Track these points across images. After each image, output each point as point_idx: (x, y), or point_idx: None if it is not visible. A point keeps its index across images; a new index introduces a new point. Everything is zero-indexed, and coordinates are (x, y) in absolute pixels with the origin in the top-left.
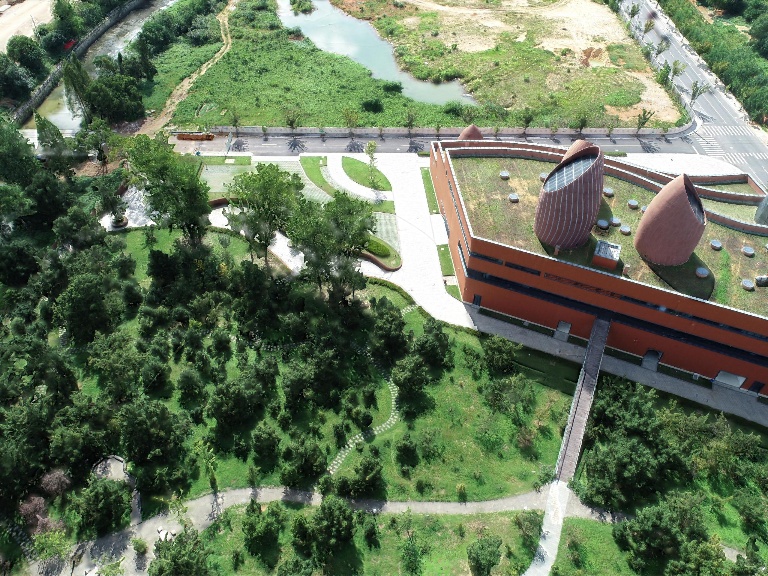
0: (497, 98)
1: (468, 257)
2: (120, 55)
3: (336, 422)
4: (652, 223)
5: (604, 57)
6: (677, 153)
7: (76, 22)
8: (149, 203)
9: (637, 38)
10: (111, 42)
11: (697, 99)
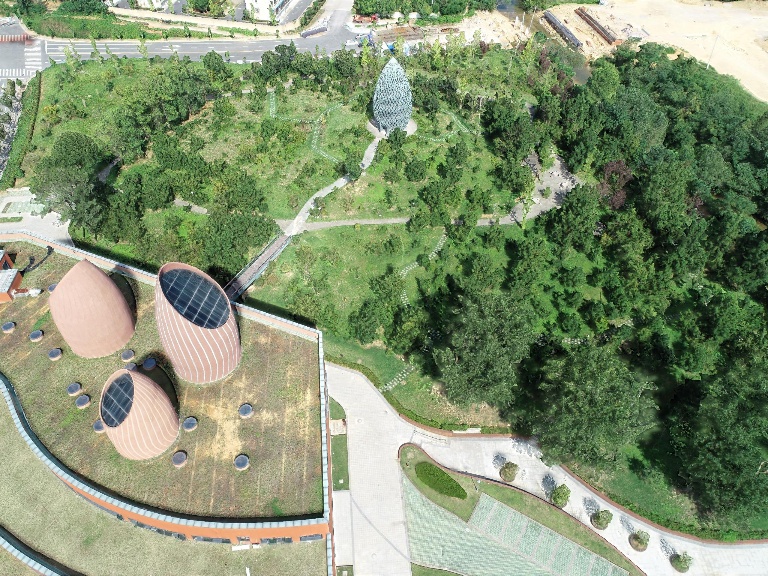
0: None
1: None
2: None
3: (448, 267)
4: None
5: None
6: None
7: None
8: None
9: None
10: None
11: None
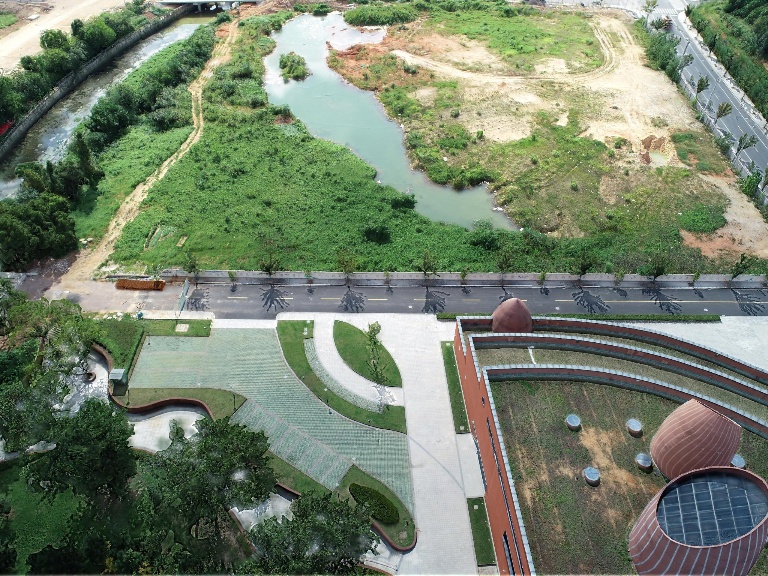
0: (538, 217)
1: None
2: (49, 164)
3: None
4: None
5: (668, 149)
6: None
7: (11, 101)
8: (31, 474)
9: (708, 123)
10: (58, 121)
11: None
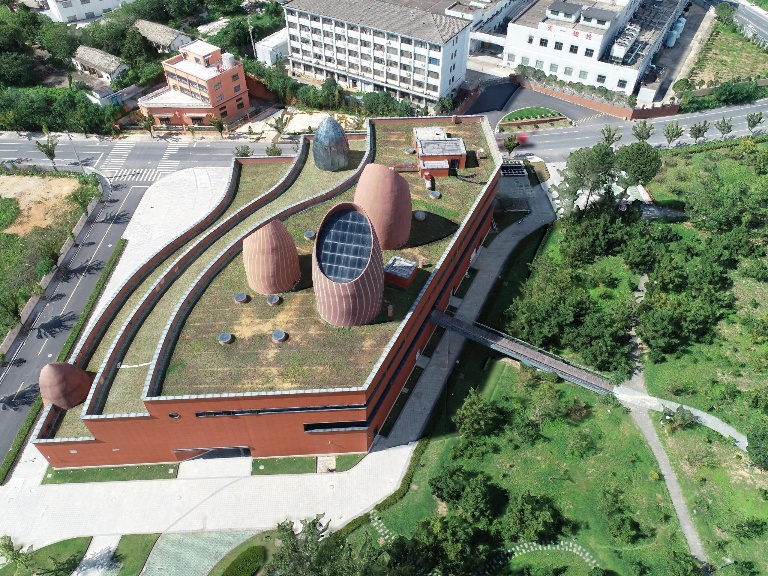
0: None
1: (364, 411)
2: None
3: None
4: (392, 218)
5: None
6: (140, 201)
7: None
8: None
9: None
10: None
11: (44, 158)
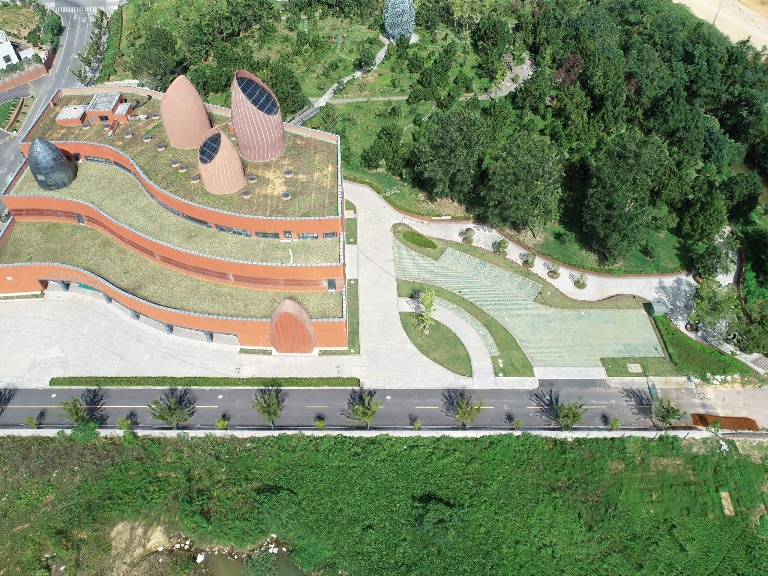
0: None
1: None
2: None
3: None
4: None
5: None
6: None
7: None
8: None
9: None
10: None
11: None
